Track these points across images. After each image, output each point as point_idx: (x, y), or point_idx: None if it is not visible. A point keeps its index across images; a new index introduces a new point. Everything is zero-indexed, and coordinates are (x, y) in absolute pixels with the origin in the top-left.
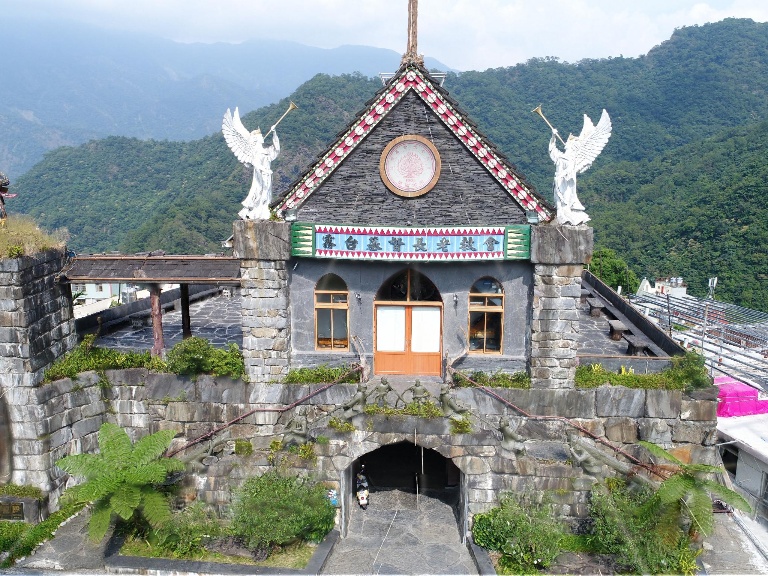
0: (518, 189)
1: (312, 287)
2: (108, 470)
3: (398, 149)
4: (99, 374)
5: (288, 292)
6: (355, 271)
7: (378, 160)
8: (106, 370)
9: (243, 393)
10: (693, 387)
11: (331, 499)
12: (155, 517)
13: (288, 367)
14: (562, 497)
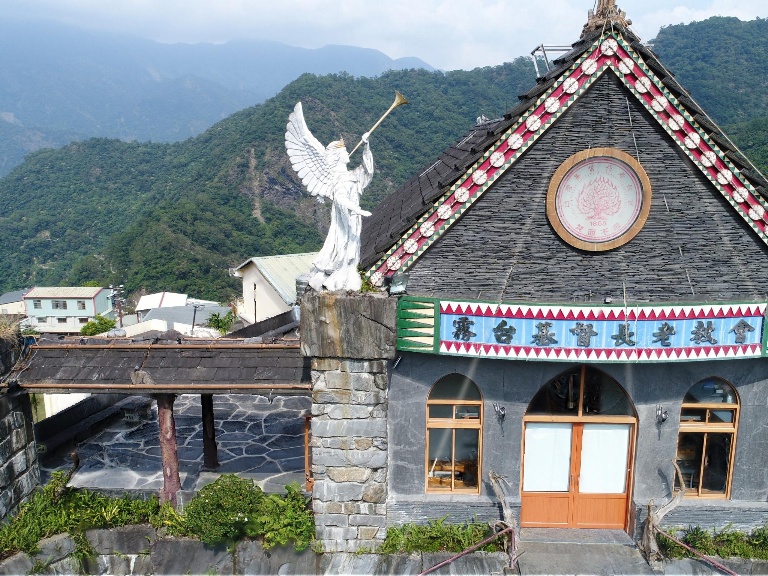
0: None
1: (423, 395)
2: None
3: (579, 172)
4: (75, 538)
5: None
6: (495, 369)
7: (543, 190)
8: (87, 530)
9: (312, 569)
10: None
11: None
12: None
13: None
14: None
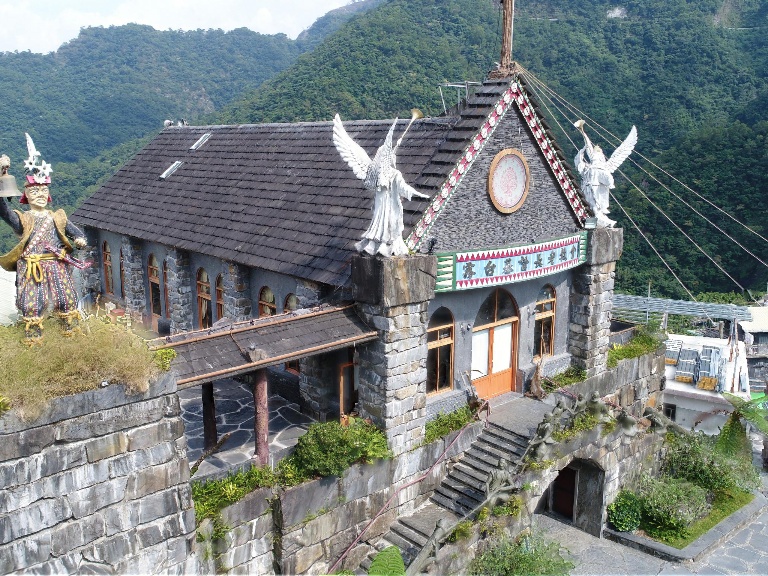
0: (574, 198)
1: None
2: None
3: (501, 164)
4: None
5: None
6: (460, 300)
7: (486, 176)
8: None
9: (388, 474)
10: None
11: None
12: None
13: None
14: None
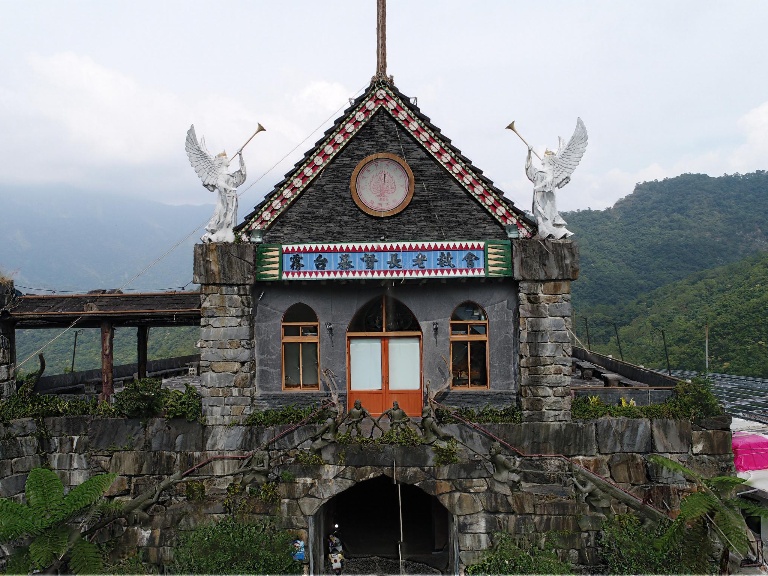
0: (496, 205)
1: (279, 318)
2: (33, 518)
3: (369, 168)
4: (36, 422)
5: (253, 324)
6: (326, 299)
7: (349, 180)
8: (45, 418)
9: (199, 438)
10: (702, 413)
11: (297, 553)
12: (83, 570)
13: (251, 408)
14: (567, 540)
